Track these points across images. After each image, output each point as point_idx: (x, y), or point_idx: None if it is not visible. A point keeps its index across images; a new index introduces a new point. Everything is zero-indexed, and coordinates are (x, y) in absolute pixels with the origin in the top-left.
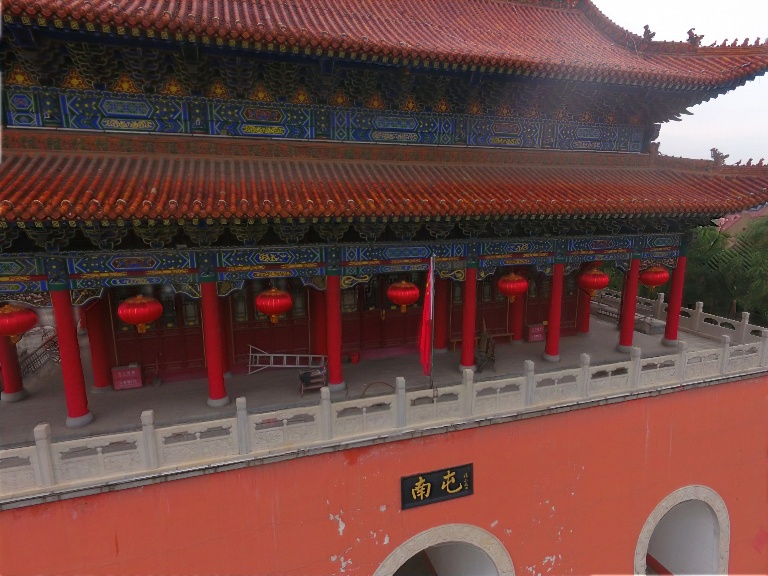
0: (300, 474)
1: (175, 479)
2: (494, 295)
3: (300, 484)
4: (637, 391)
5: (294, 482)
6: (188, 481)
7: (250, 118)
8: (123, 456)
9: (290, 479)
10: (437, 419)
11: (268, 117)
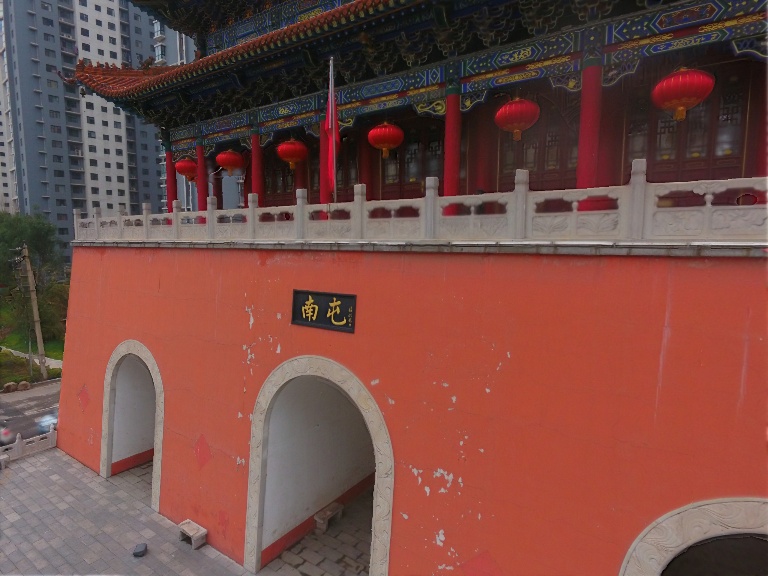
0: (234, 264)
1: (179, 247)
2: (564, 160)
3: (233, 273)
4: (632, 241)
5: (230, 270)
6: (186, 252)
7: (301, 9)
8: (168, 228)
9: (228, 267)
10: (330, 238)
11: (311, 3)
